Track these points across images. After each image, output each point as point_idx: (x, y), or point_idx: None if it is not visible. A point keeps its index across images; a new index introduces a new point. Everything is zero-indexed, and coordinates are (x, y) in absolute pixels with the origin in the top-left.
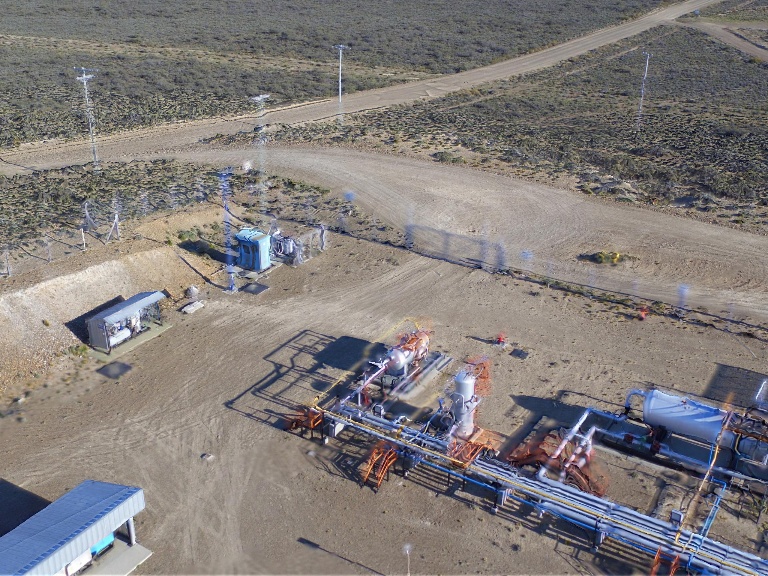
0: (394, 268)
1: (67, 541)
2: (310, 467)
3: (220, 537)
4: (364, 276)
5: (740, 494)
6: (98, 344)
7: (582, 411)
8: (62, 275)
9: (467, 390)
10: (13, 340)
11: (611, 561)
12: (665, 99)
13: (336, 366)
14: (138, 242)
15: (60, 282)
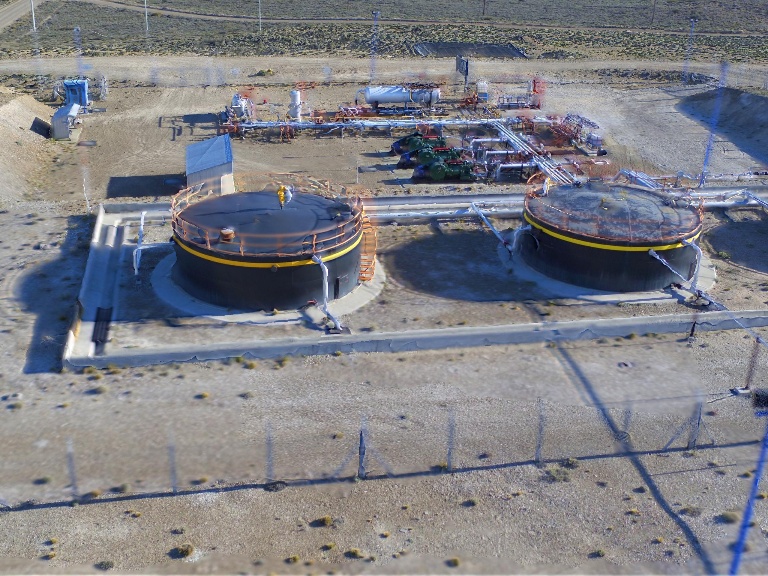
0: (162, 93)
1: (230, 145)
2: (251, 145)
3: (251, 164)
4: (151, 98)
5: (419, 116)
6: (60, 136)
7: (333, 113)
8: (3, 105)
9: (298, 99)
10: (18, 136)
11: (400, 137)
12: (131, 38)
13: (202, 122)
14: (6, 94)
15: (6, 109)
